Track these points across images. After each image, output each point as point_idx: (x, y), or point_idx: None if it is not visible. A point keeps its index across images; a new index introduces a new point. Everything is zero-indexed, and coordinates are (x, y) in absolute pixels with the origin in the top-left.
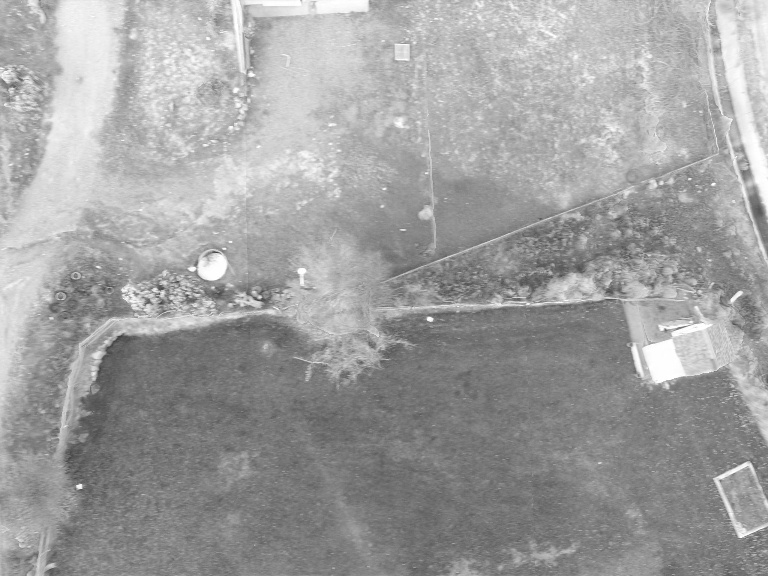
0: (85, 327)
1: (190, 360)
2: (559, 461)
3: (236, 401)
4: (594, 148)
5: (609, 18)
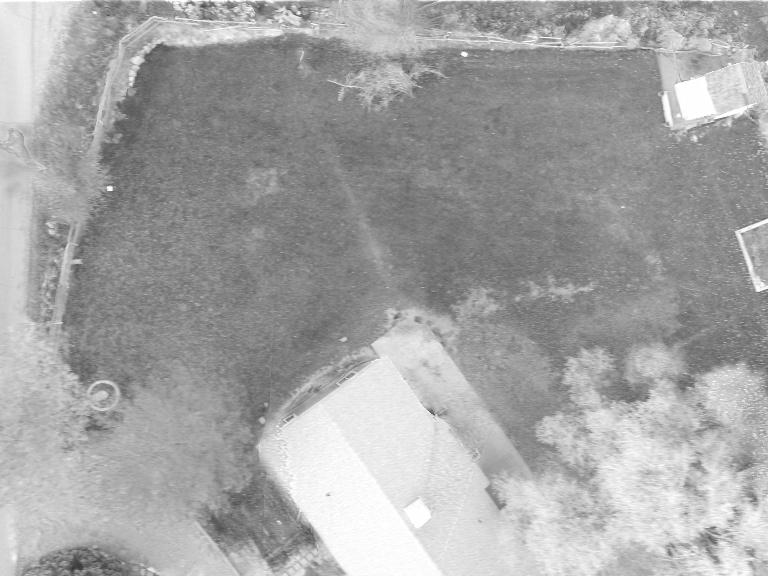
0: (126, 28)
1: (226, 74)
2: (583, 201)
3: (268, 118)
4: None
5: None
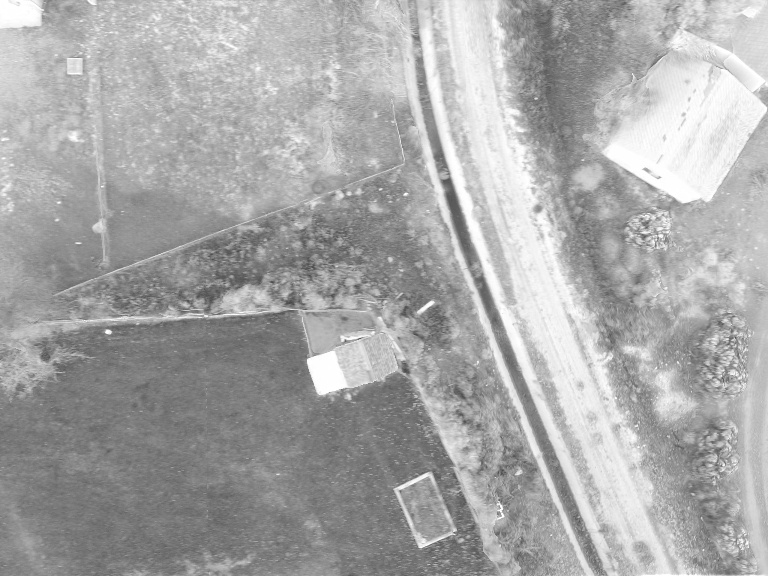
0: None
1: None
2: (236, 473)
3: None
4: (278, 159)
5: (294, 29)
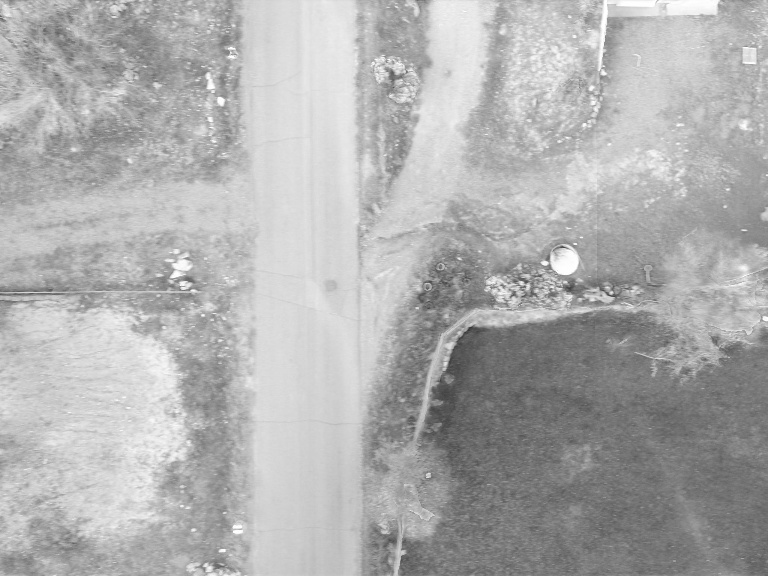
0: (444, 318)
1: (536, 353)
2: None
3: (580, 394)
4: None
5: None
